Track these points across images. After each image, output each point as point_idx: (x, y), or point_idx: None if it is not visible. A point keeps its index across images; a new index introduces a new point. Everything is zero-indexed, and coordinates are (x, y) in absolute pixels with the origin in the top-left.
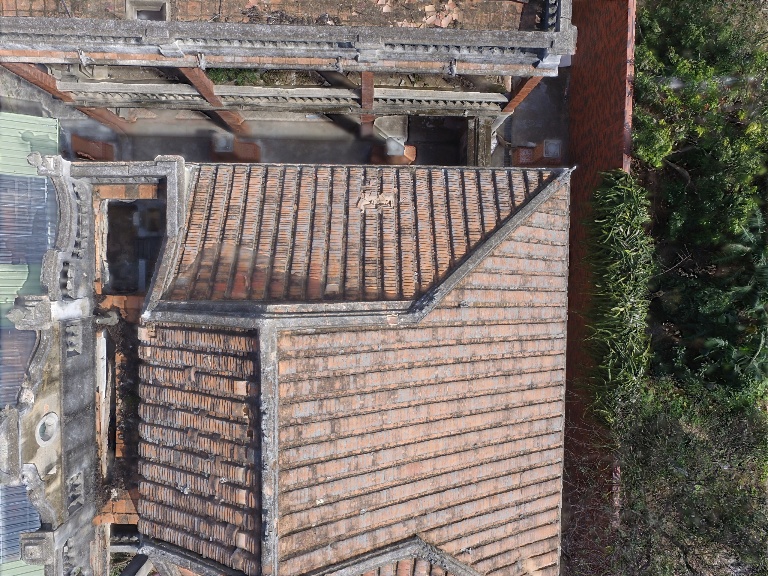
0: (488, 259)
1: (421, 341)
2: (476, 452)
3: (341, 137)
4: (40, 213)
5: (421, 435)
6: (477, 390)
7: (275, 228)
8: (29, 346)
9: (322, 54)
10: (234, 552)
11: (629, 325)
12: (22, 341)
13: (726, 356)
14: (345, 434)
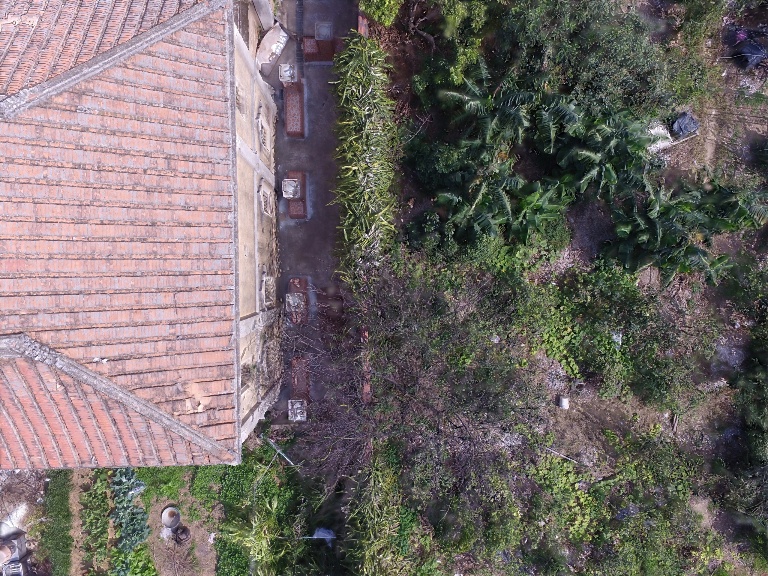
0: (116, 69)
1: (22, 138)
2: (109, 262)
3: None
4: None
5: (27, 233)
6: (108, 200)
7: None
8: None
9: None
10: None
11: (361, 184)
12: None
13: (458, 212)
14: None
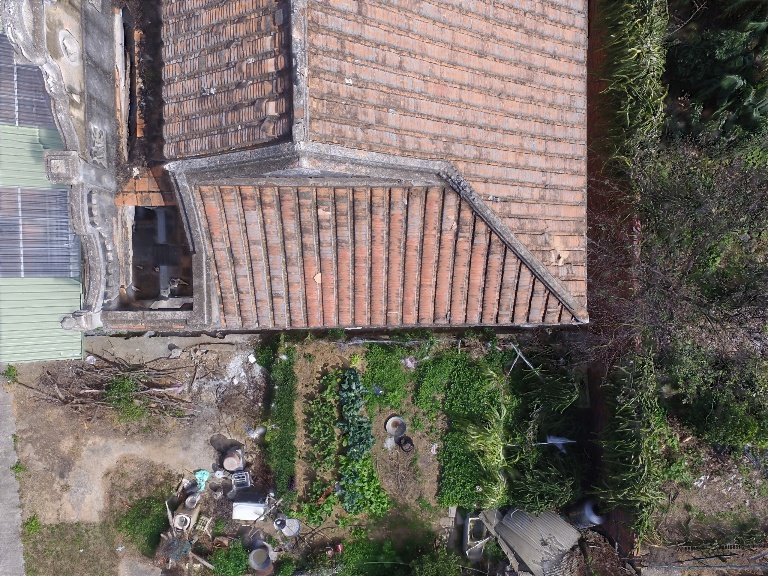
0: None
1: None
2: (501, 101)
3: None
4: None
5: (447, 60)
6: (501, 38)
7: None
8: None
9: None
10: (264, 121)
11: (646, 66)
12: None
13: (745, 94)
14: (372, 24)
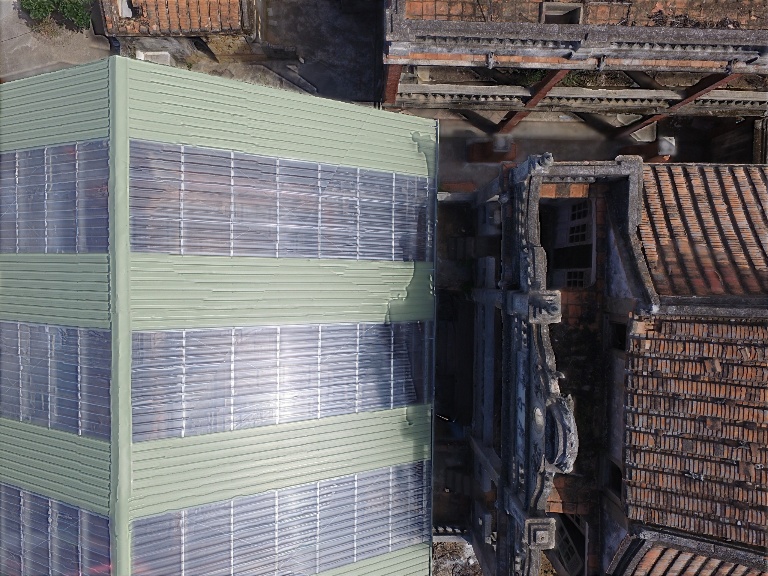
0: None
1: None
2: None
3: (592, 137)
4: (423, 211)
5: None
6: None
7: (715, 225)
8: (413, 341)
9: (721, 57)
10: None
11: None
12: (408, 336)
13: None
14: None
